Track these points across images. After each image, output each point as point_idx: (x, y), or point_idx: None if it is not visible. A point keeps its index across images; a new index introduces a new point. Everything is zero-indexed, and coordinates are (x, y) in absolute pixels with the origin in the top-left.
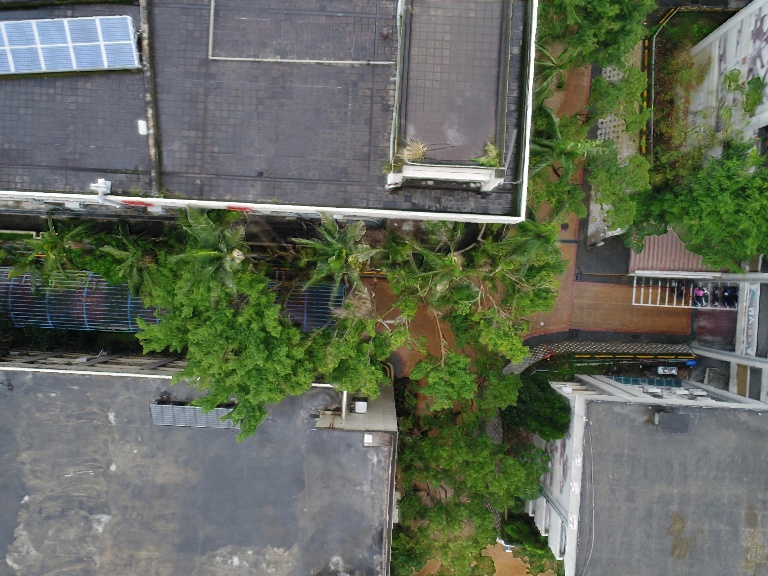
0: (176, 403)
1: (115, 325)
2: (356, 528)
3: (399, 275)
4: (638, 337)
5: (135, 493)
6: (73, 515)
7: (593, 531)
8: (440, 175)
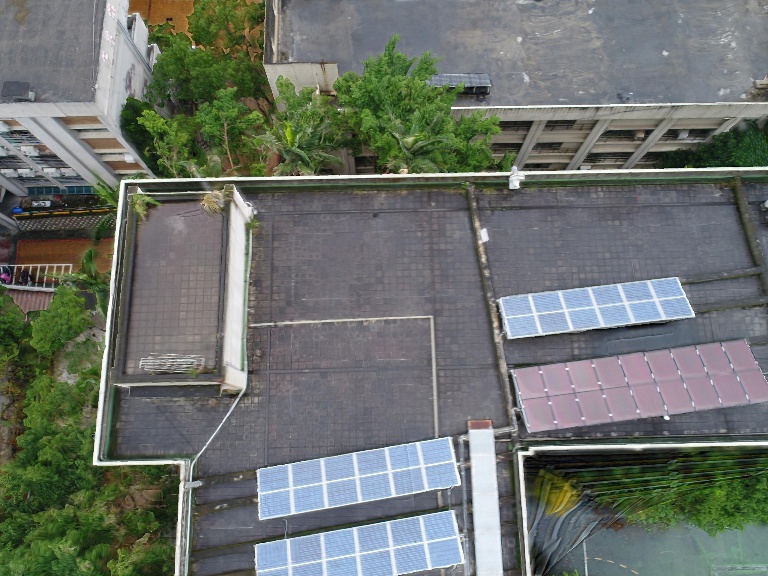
0: (471, 93)
1: None
2: (305, 7)
3: None
4: (69, 235)
5: (498, 21)
6: (548, 2)
7: (95, 7)
8: None
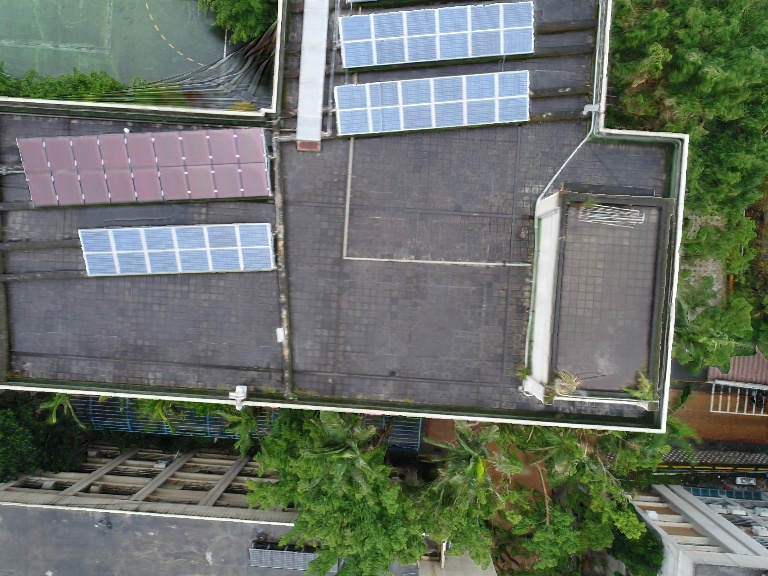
0: (273, 544)
1: (193, 431)
2: None
3: (508, 437)
4: (715, 444)
5: None
6: None
7: None
8: (587, 399)
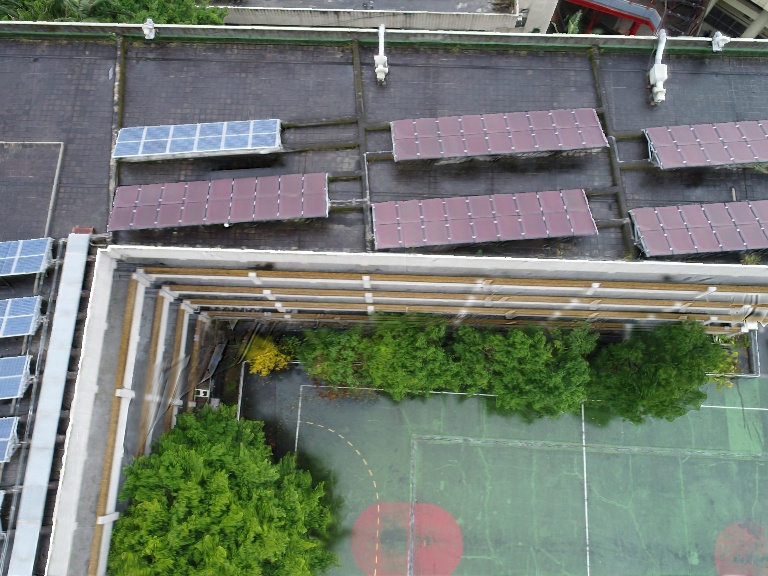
0: None
1: None
2: None
3: None
4: None
5: None
6: None
7: None
8: None
